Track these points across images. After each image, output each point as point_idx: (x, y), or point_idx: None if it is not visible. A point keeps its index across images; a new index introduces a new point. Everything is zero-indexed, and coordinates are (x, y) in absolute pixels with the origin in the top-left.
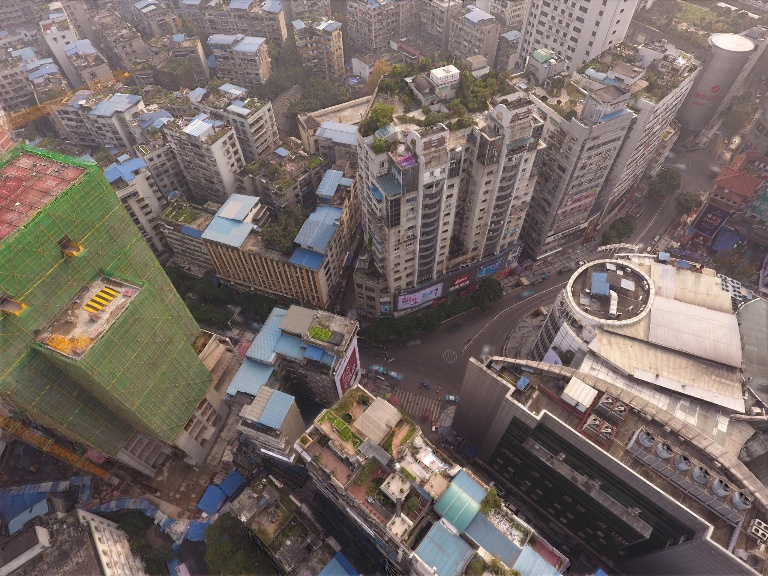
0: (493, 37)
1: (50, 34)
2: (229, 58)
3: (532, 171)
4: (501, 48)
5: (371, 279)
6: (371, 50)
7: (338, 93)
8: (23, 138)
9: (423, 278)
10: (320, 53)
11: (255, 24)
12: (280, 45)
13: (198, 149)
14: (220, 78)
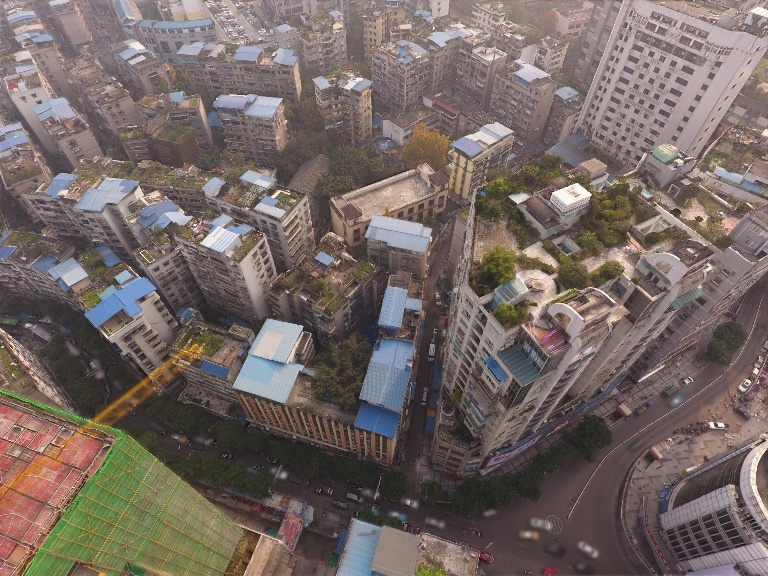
0: (548, 97)
1: (17, 93)
2: (240, 123)
3: (675, 312)
4: (552, 106)
5: (462, 444)
6: (401, 107)
7: (371, 164)
8: None
9: (522, 432)
10: (346, 114)
11: (265, 77)
12: (294, 100)
13: (221, 264)
14: (227, 144)
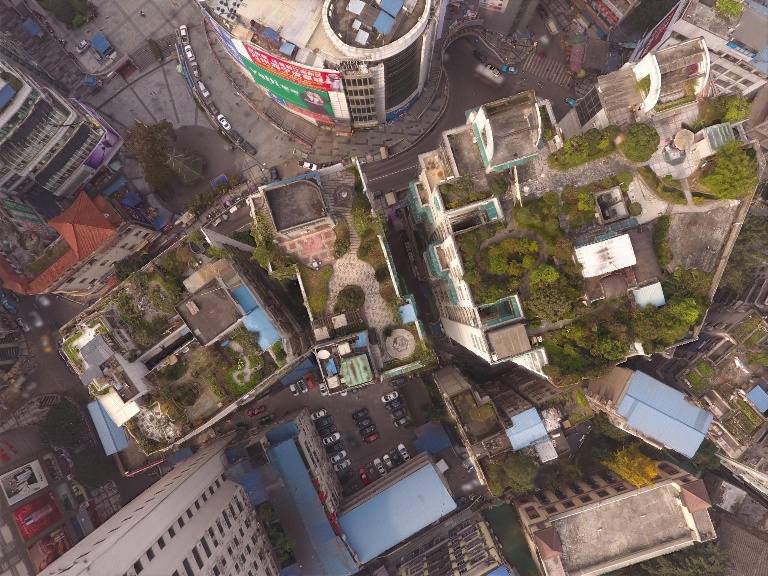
0: None
1: None
2: None
3: None
4: None
5: None
6: None
7: None
8: None
9: None
10: None
11: None
12: None
13: None
14: None
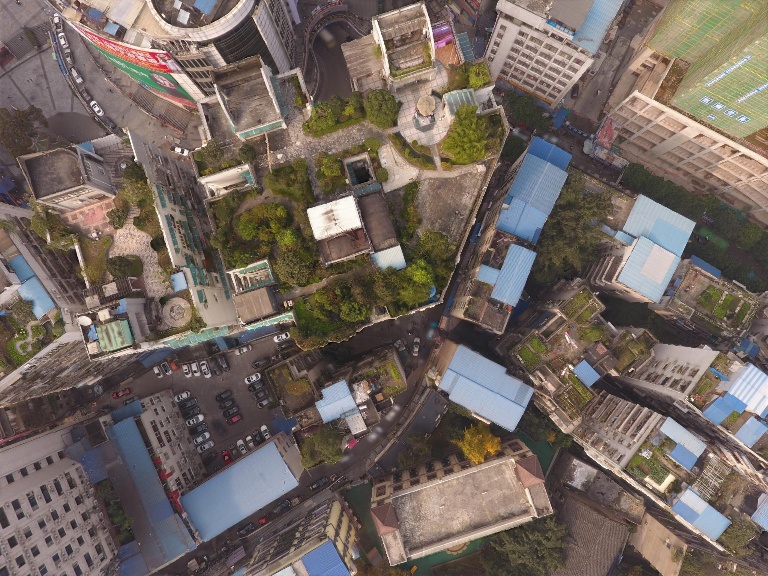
0: None
1: None
2: None
3: None
4: None
5: None
6: None
7: None
8: None
9: None
10: None
11: None
12: None
13: None
14: None
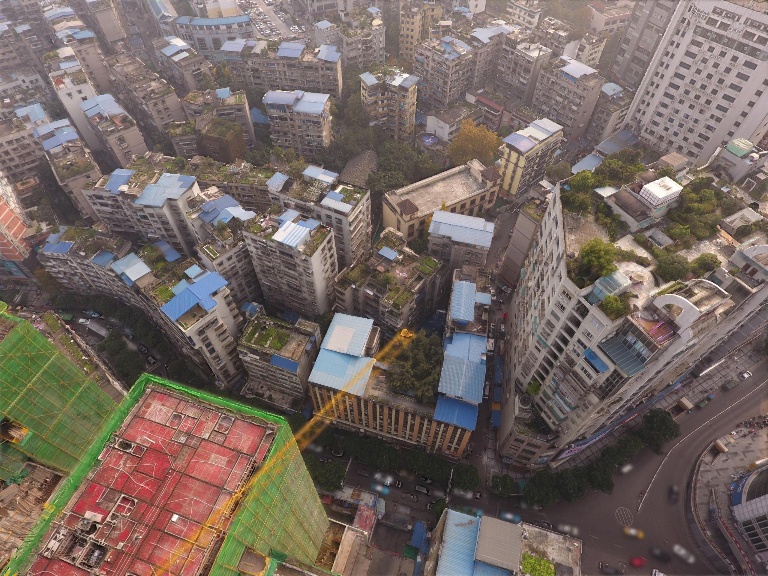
0: (595, 93)
1: (64, 89)
2: (287, 119)
3: None
4: None
5: (540, 437)
6: (443, 103)
7: (419, 159)
8: (38, 221)
9: None
10: (391, 110)
11: (307, 74)
12: (335, 96)
13: (290, 258)
14: (273, 140)
